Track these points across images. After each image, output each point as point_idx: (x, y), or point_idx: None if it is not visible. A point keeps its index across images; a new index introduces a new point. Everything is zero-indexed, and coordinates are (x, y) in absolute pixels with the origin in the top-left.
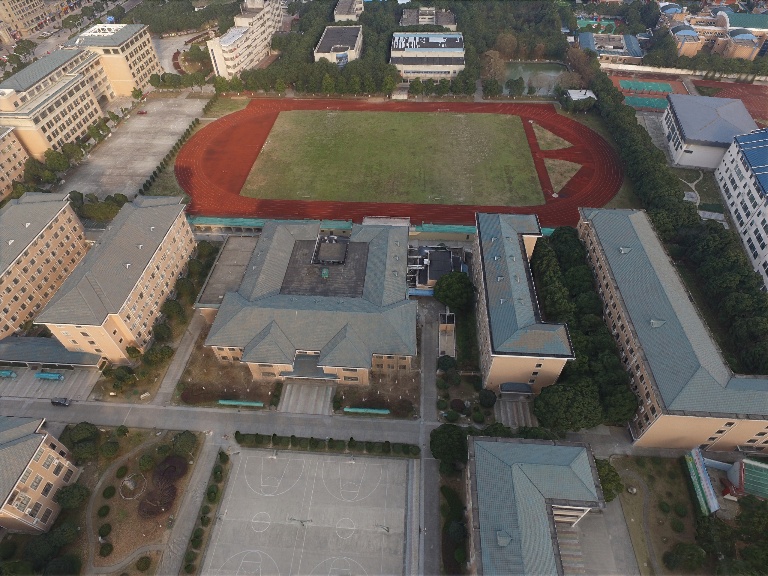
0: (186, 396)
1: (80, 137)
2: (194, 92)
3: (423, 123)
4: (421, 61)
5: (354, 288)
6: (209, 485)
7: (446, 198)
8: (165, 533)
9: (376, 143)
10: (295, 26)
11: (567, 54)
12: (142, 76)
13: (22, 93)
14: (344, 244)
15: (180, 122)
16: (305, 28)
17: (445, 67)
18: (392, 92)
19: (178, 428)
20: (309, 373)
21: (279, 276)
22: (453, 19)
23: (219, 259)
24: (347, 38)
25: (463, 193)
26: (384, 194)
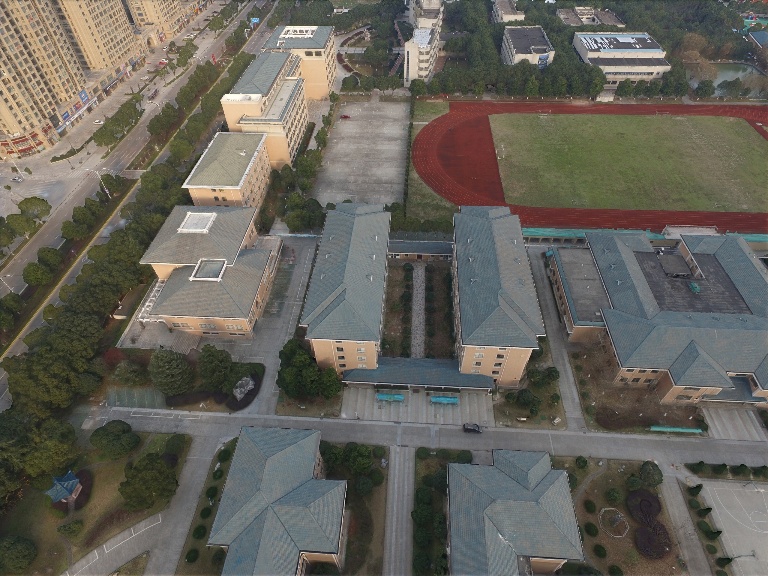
0: (605, 421)
1: (300, 143)
2: (384, 95)
3: (647, 126)
4: (621, 62)
5: (735, 304)
6: (695, 521)
7: (728, 205)
8: (683, 575)
9: (613, 147)
10: (442, 27)
11: (757, 54)
12: (330, 79)
13: (264, 98)
14: (679, 256)
15: (391, 126)
16: (470, 29)
17: (650, 68)
18: (599, 94)
19: (616, 457)
20: (735, 396)
21: (648, 291)
22: (616, 19)
23: (564, 273)
24: (535, 39)
25: (742, 200)
26: (659, 201)
